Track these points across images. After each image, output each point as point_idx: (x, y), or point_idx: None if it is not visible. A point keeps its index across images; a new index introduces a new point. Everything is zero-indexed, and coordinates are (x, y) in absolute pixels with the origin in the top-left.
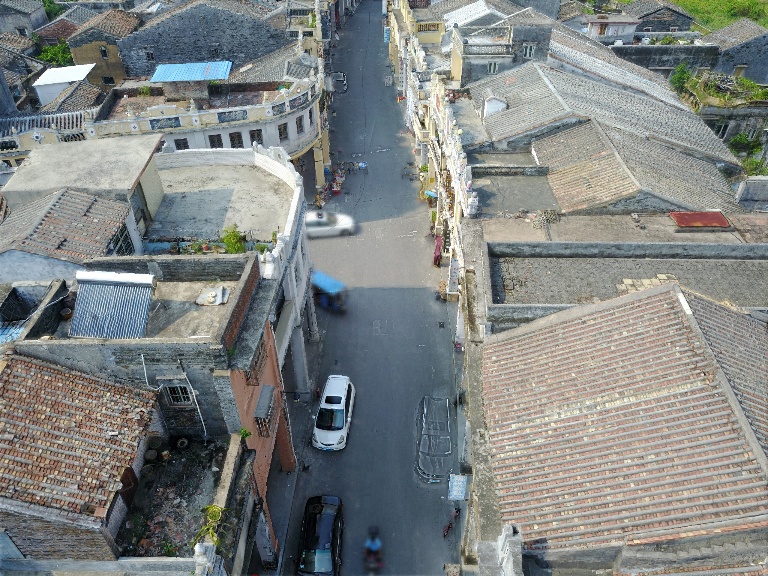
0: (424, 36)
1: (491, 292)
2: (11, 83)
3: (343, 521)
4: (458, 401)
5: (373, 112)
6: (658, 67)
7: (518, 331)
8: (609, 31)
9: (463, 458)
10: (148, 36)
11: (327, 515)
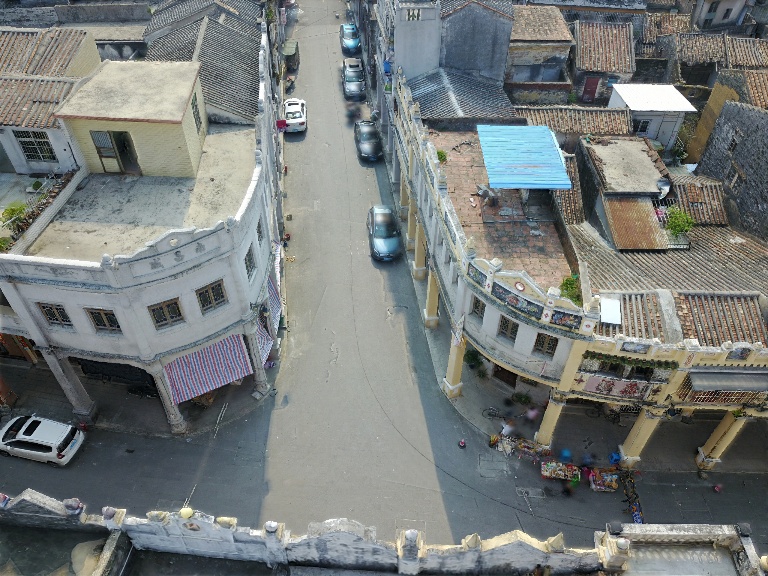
0: None
1: None
2: (608, 70)
3: None
4: None
5: None
6: None
7: None
8: None
9: None
10: (748, 120)
11: None
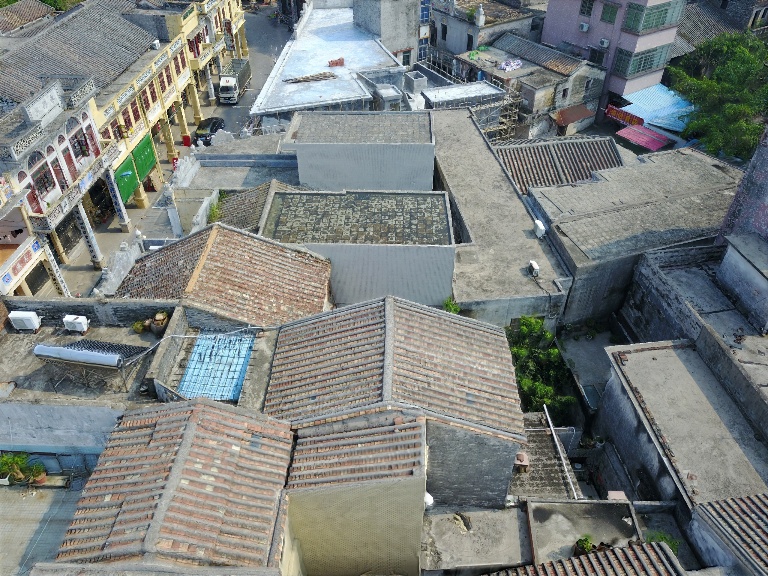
0: None
1: None
2: None
3: None
4: None
5: None
6: None
7: None
8: None
9: None
10: None
11: None
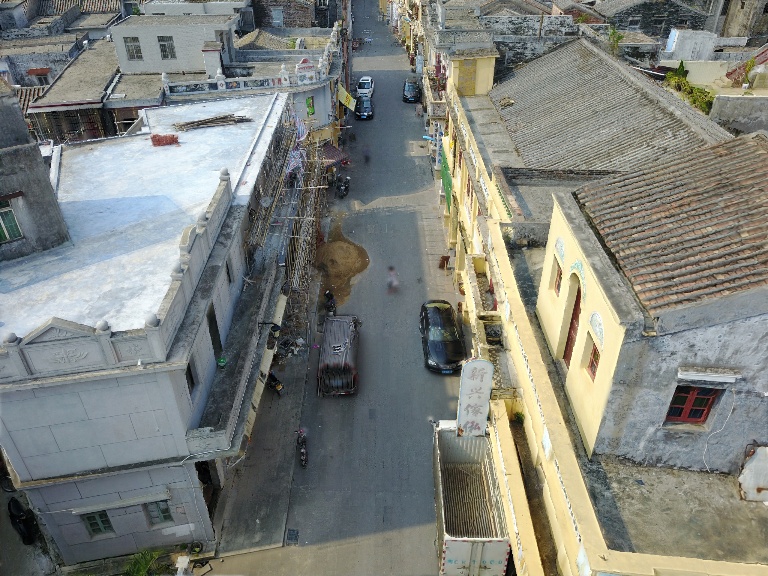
0: None
1: None
2: None
3: None
4: None
5: (372, 29)
6: None
7: None
8: None
9: None
10: None
11: None
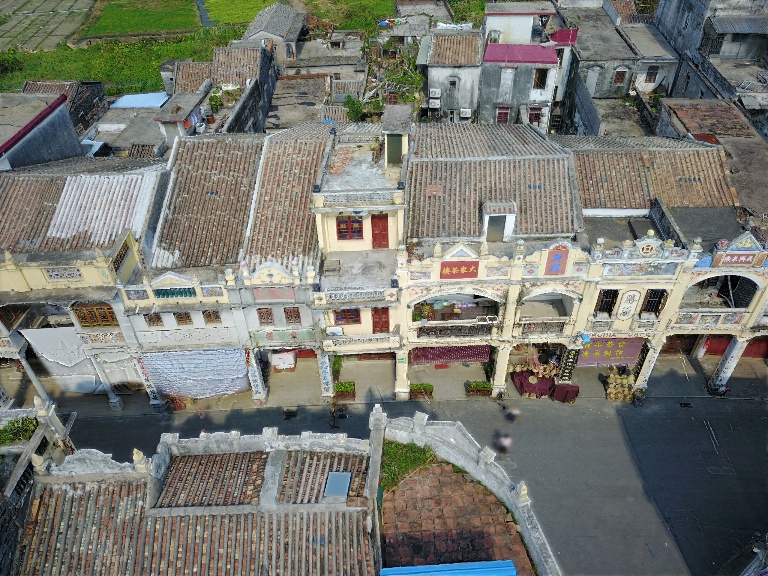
0: (123, 272)
1: None
2: None
3: None
4: None
5: None
6: (247, 125)
7: None
8: (195, 119)
9: None
10: None
11: None
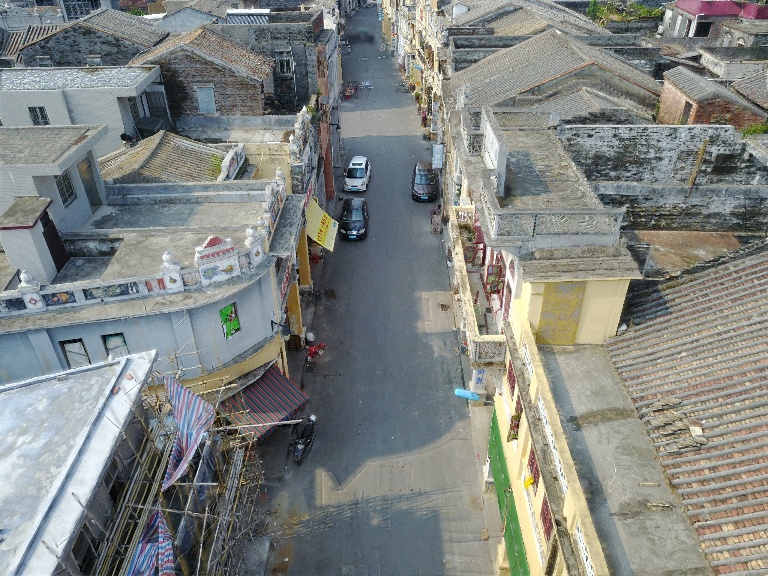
0: None
1: (454, 47)
2: None
3: (367, 213)
4: (439, 175)
5: (372, 63)
6: None
7: (470, 67)
8: None
9: (442, 183)
10: None
11: (358, 200)
